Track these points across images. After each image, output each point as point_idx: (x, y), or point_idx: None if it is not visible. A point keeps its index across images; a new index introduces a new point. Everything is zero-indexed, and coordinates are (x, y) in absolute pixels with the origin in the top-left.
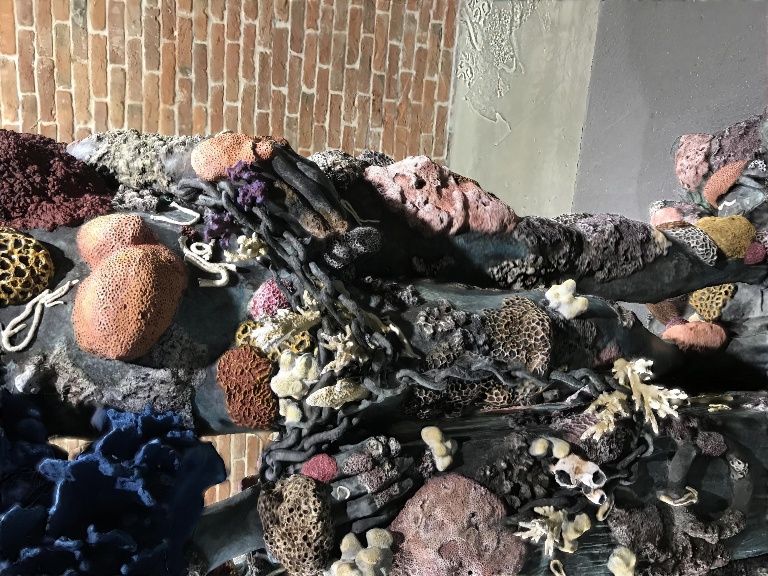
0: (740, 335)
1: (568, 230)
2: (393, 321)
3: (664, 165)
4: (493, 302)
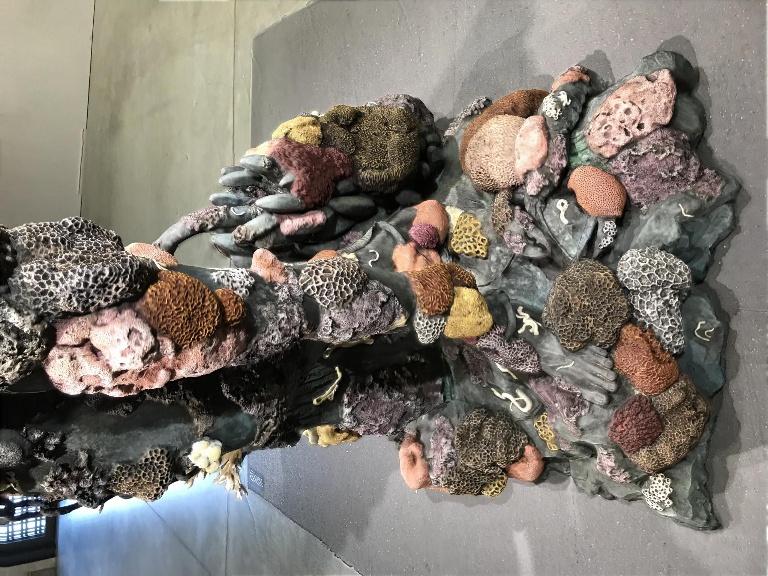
0: (459, 264)
1: (301, 334)
2: (17, 478)
3: (665, 2)
4: (137, 451)
